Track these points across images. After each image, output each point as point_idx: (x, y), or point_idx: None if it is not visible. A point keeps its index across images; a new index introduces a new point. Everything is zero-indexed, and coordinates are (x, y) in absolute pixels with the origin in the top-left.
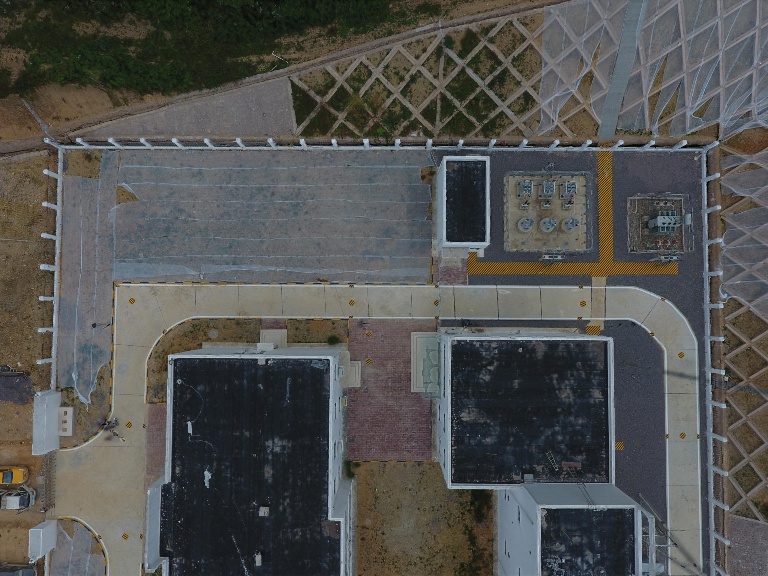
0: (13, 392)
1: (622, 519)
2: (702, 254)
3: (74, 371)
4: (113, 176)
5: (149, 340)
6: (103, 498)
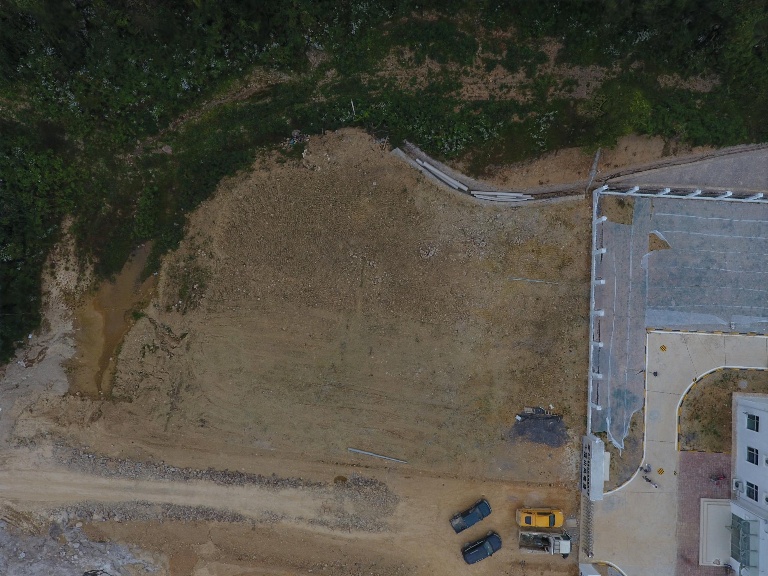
0: (552, 435)
1: None
2: None
3: (608, 416)
4: (645, 223)
5: (680, 388)
6: (636, 544)
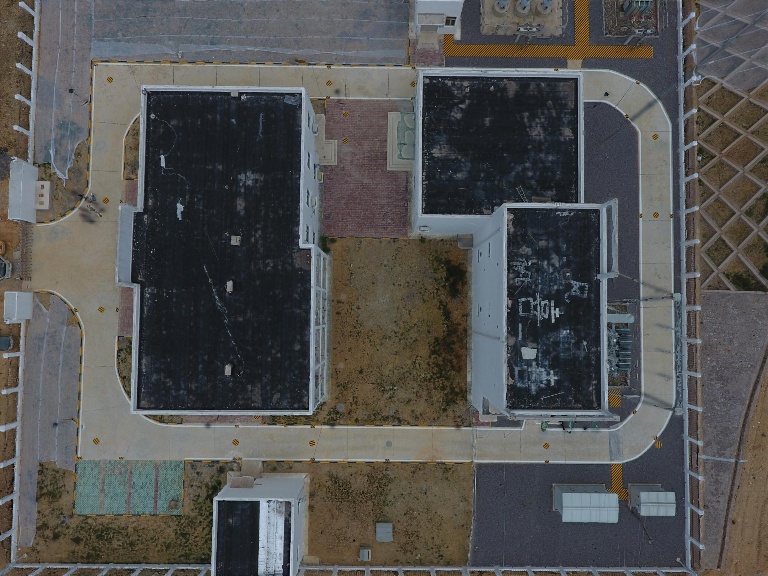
0: None
1: (588, 223)
2: (677, 38)
3: (51, 147)
4: None
5: (127, 118)
6: (79, 272)
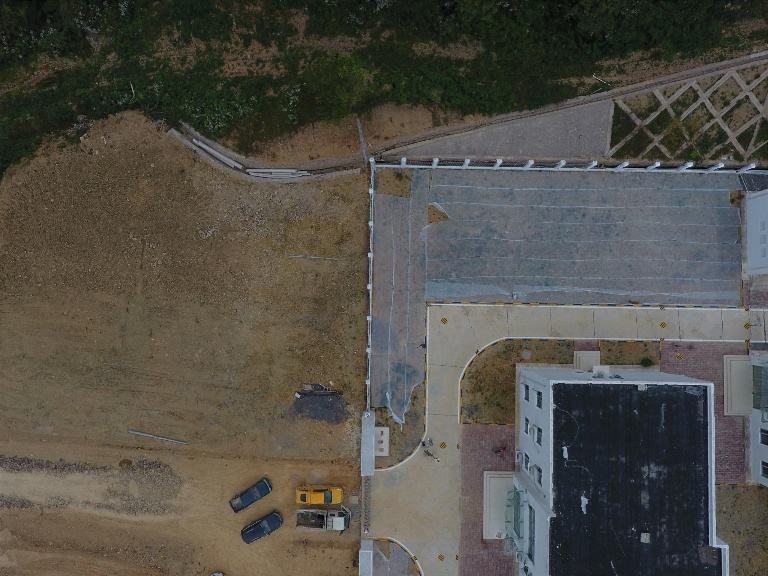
0: (329, 411)
1: None
2: None
3: (388, 391)
4: (424, 195)
5: (462, 360)
6: (418, 519)
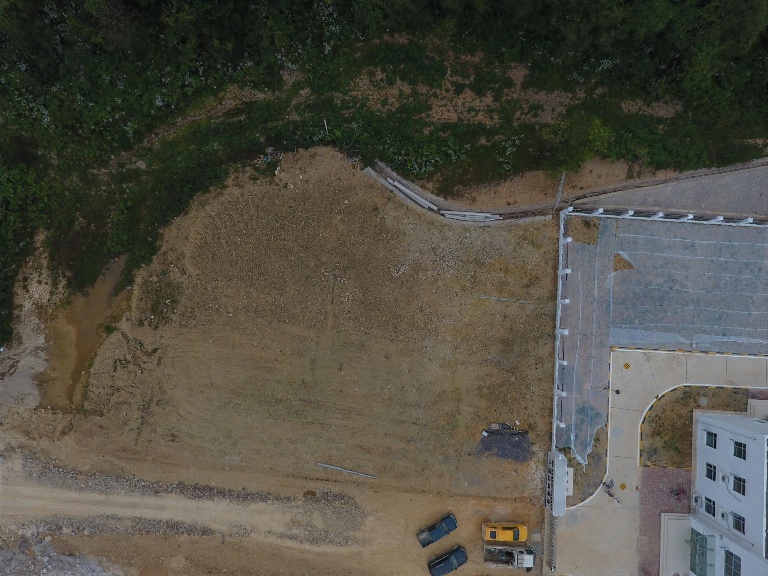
0: (517, 451)
1: None
2: None
3: (572, 432)
4: (610, 244)
5: (642, 405)
6: (598, 557)
